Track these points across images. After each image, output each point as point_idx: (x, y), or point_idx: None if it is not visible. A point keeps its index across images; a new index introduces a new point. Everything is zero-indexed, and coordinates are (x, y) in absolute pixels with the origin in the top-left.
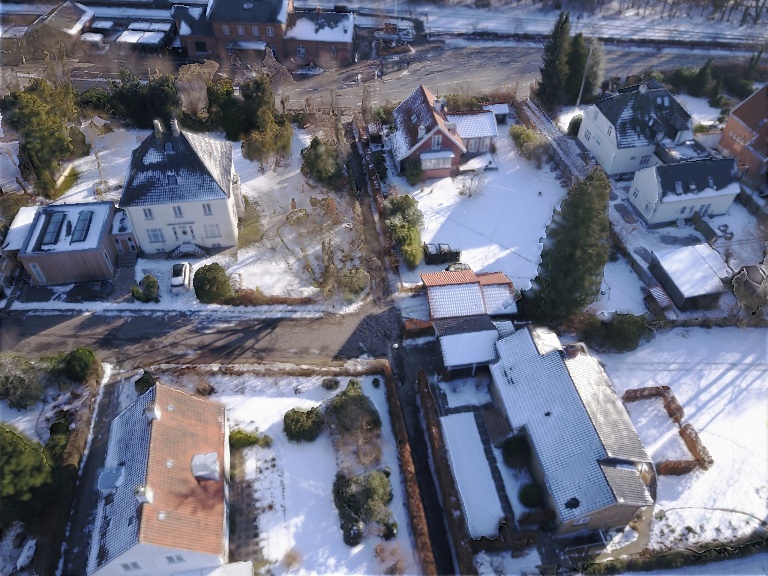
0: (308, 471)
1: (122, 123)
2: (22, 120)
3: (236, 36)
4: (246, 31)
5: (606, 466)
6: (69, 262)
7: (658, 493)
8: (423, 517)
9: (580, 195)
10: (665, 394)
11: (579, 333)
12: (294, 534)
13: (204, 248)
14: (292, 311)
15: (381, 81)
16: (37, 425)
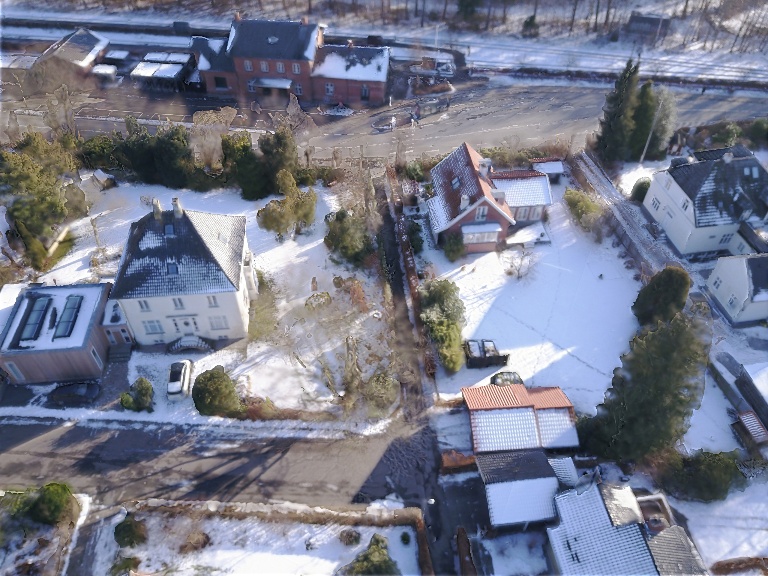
0: None
1: (128, 176)
2: (9, 184)
3: (259, 72)
4: (270, 67)
5: None
6: (51, 361)
7: None
8: None
9: (675, 334)
10: None
11: (656, 479)
12: None
13: (209, 340)
14: (307, 429)
15: (417, 126)
16: None
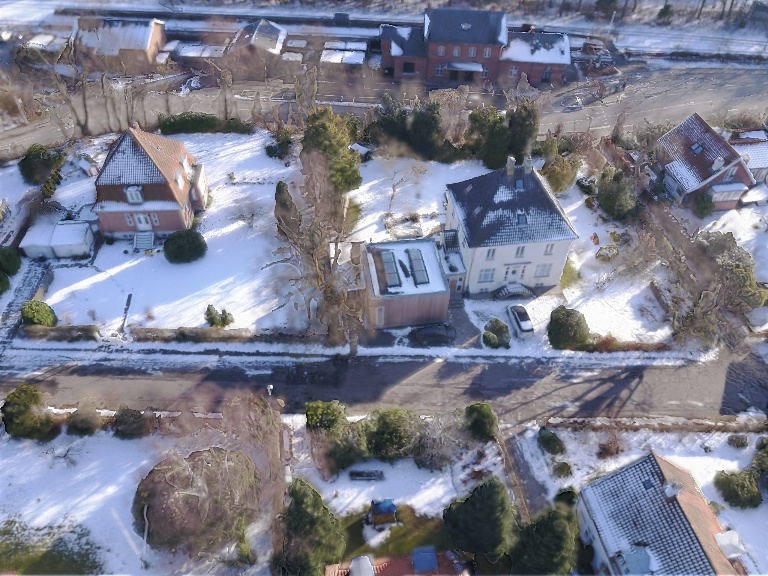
0: (767, 542)
1: (376, 150)
2: (328, 152)
3: (450, 57)
4: (462, 52)
5: None
6: (416, 305)
7: None
8: None
9: None
10: None
11: None
12: None
13: (528, 288)
14: (650, 358)
15: (603, 104)
16: (456, 488)
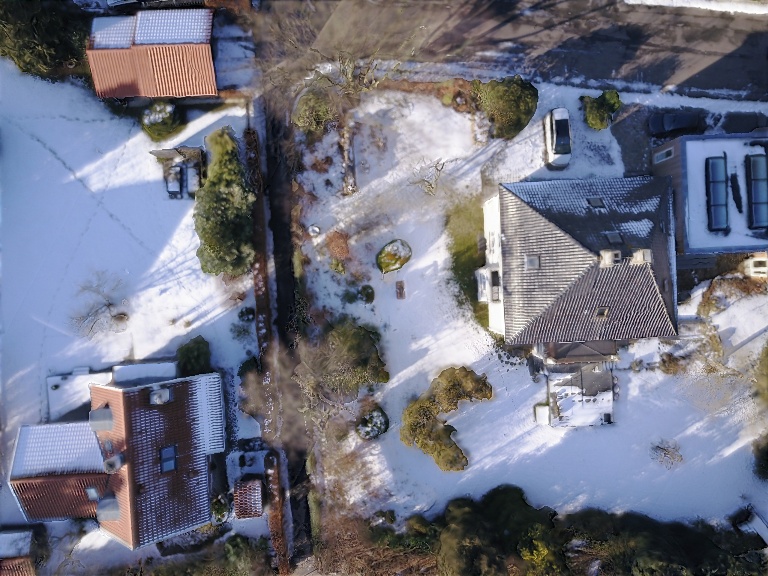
0: None
1: None
2: None
3: None
4: None
5: None
6: None
7: None
8: None
9: None
10: None
11: None
12: None
13: None
14: (402, 71)
15: None
16: None
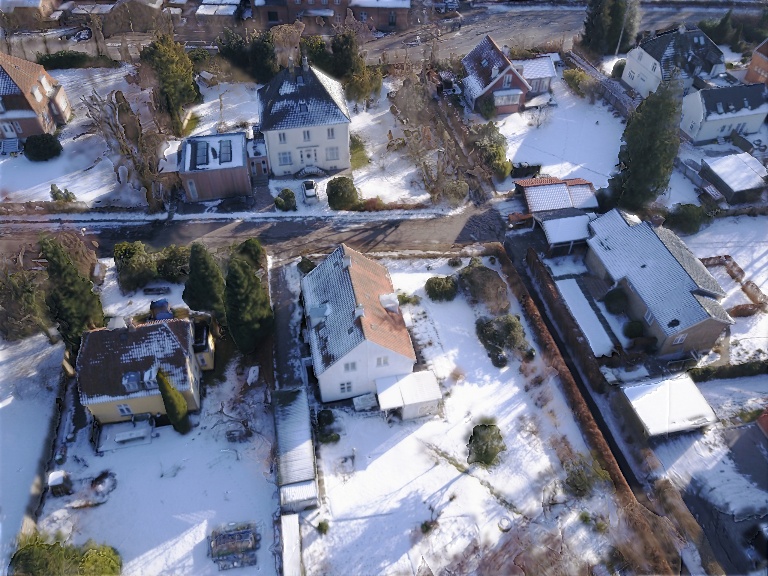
0: (453, 321)
1: (224, 78)
2: (160, 67)
3: (306, 5)
4: (315, 0)
5: (698, 295)
6: (220, 179)
7: (731, 329)
8: (554, 344)
9: (660, 93)
10: (726, 263)
11: None
12: (454, 360)
13: (323, 170)
14: (409, 214)
15: (438, 41)
16: None
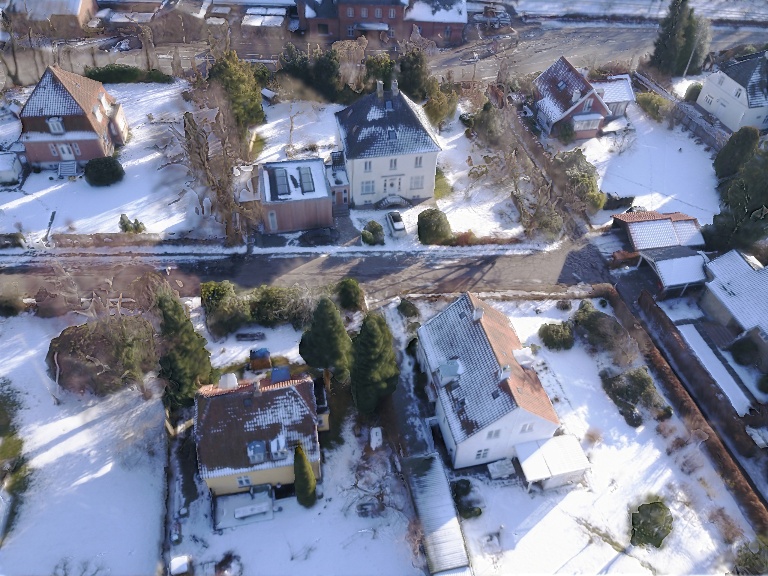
0: (575, 372)
1: (284, 95)
2: (230, 87)
3: (359, 18)
4: (369, 13)
5: None
6: (303, 210)
7: None
8: (692, 401)
9: None
10: None
11: (764, 258)
12: (585, 419)
13: (406, 199)
14: (504, 249)
15: (497, 58)
16: None
